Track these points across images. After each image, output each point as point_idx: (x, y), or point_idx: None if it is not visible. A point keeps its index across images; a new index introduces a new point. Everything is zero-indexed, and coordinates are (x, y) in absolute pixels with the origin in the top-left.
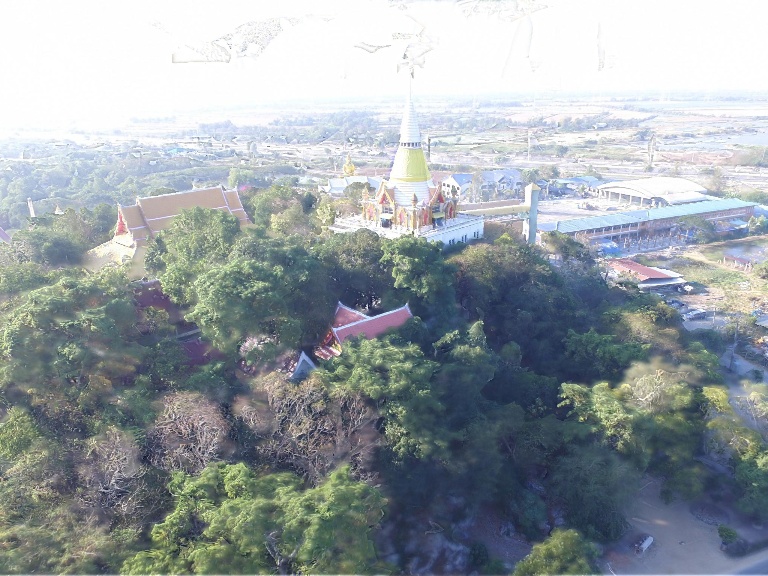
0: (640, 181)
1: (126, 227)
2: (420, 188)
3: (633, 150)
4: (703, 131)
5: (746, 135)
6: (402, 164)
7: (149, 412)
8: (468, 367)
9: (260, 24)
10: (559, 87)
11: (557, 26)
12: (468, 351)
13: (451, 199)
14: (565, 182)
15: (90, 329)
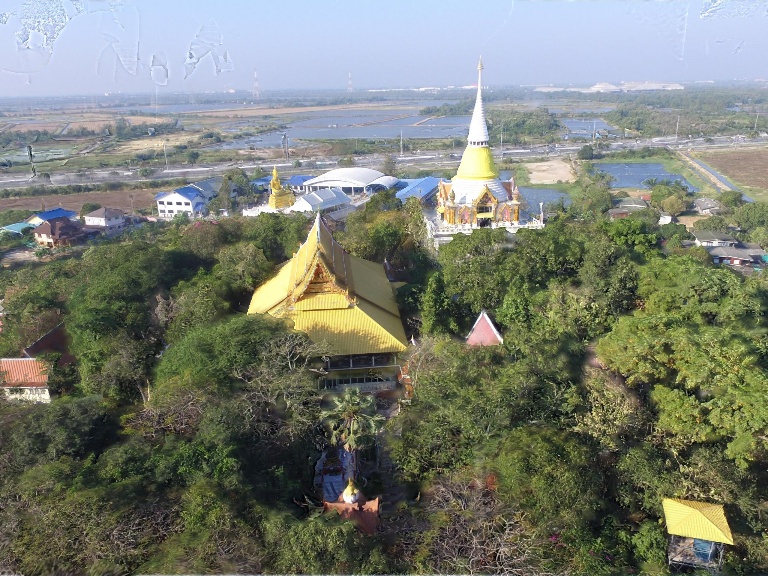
0: (340, 173)
1: (333, 283)
2: (500, 184)
3: (235, 151)
4: (254, 130)
5: (286, 131)
6: (485, 163)
7: None
8: (764, 299)
9: (38, 4)
10: (181, 91)
11: (162, 27)
12: (759, 288)
13: None
14: (260, 184)
15: (766, 347)
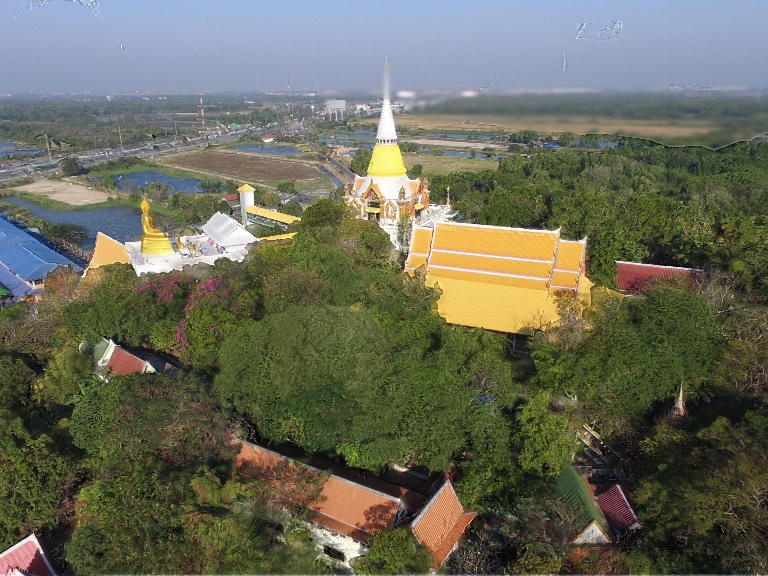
0: None
1: None
2: None
3: None
4: None
5: None
6: None
7: None
8: None
9: None
10: None
11: None
12: None
13: None
14: None
15: None
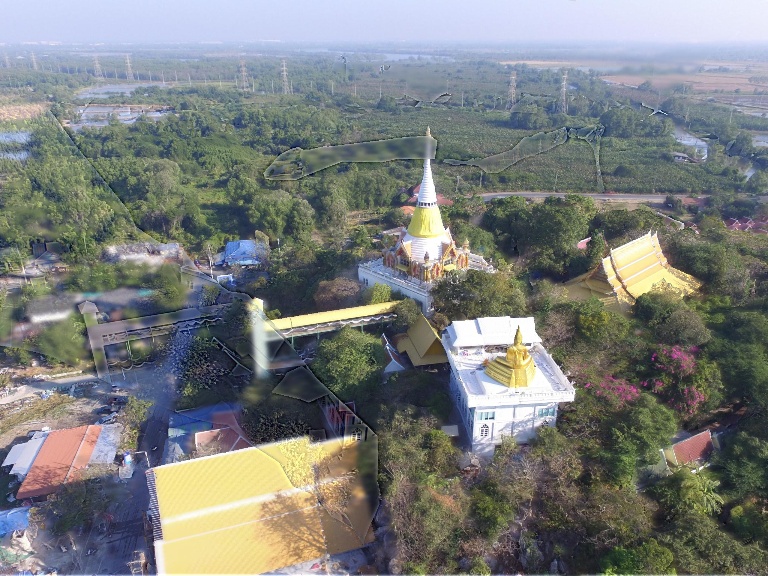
0: None
1: None
2: None
3: None
4: None
5: None
6: None
7: None
8: None
9: None
10: None
11: None
12: None
13: (390, 248)
14: None
15: None
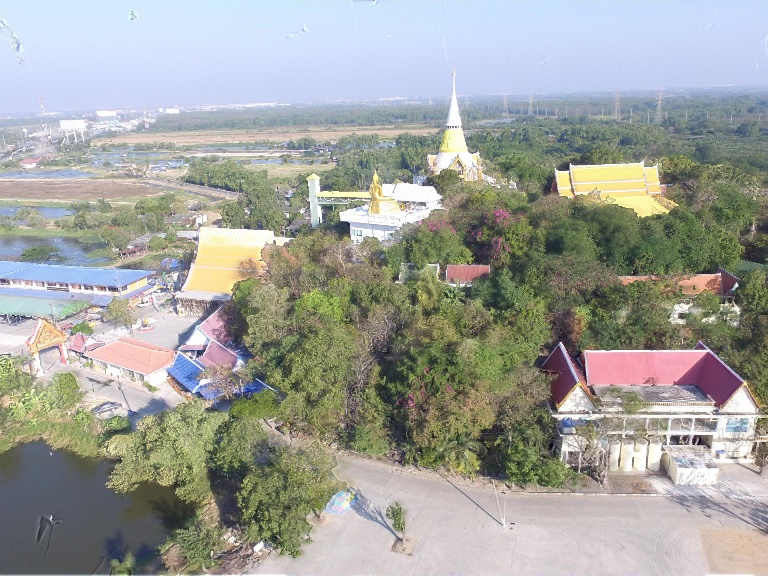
0: None
1: None
2: None
3: None
4: None
5: None
6: None
7: None
8: None
9: None
10: None
11: None
12: None
13: None
14: None
15: None
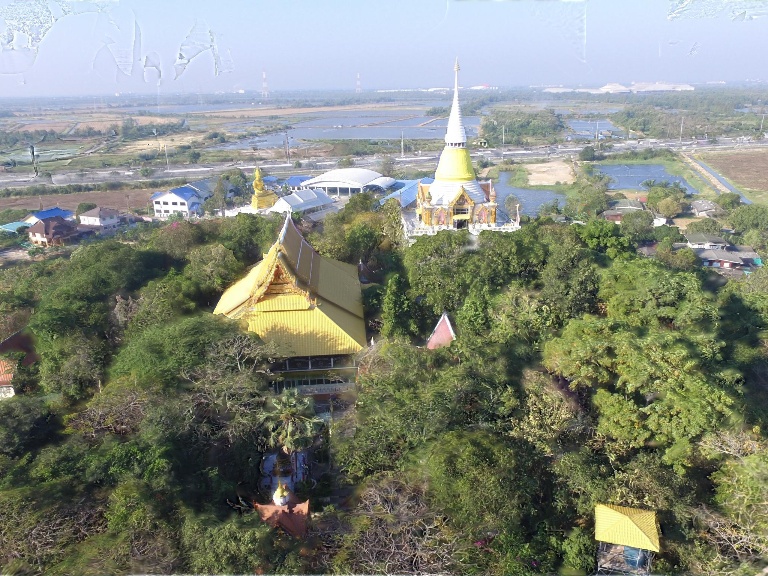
0: (337, 174)
1: (293, 285)
2: (478, 185)
3: (237, 151)
4: None
5: (291, 132)
6: (462, 164)
7: (764, 410)
8: None
9: (23, 5)
10: (182, 92)
11: (164, 28)
12: (732, 291)
13: None
14: None
15: (714, 352)
